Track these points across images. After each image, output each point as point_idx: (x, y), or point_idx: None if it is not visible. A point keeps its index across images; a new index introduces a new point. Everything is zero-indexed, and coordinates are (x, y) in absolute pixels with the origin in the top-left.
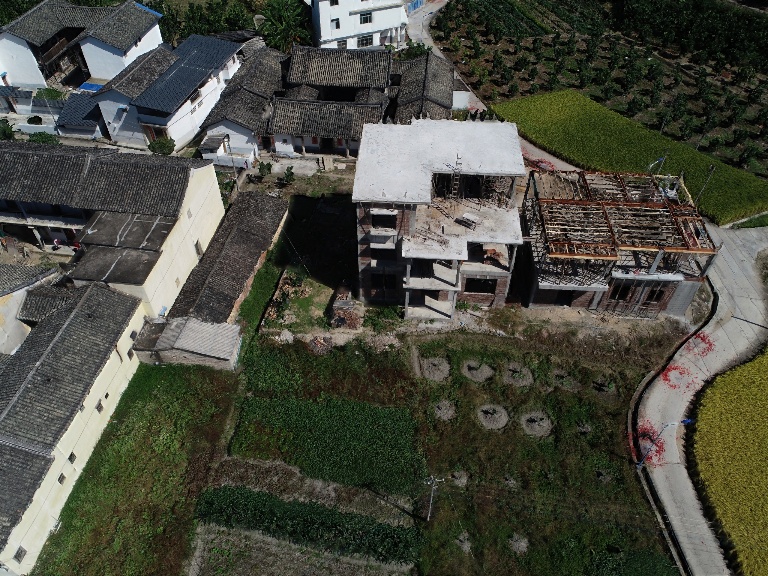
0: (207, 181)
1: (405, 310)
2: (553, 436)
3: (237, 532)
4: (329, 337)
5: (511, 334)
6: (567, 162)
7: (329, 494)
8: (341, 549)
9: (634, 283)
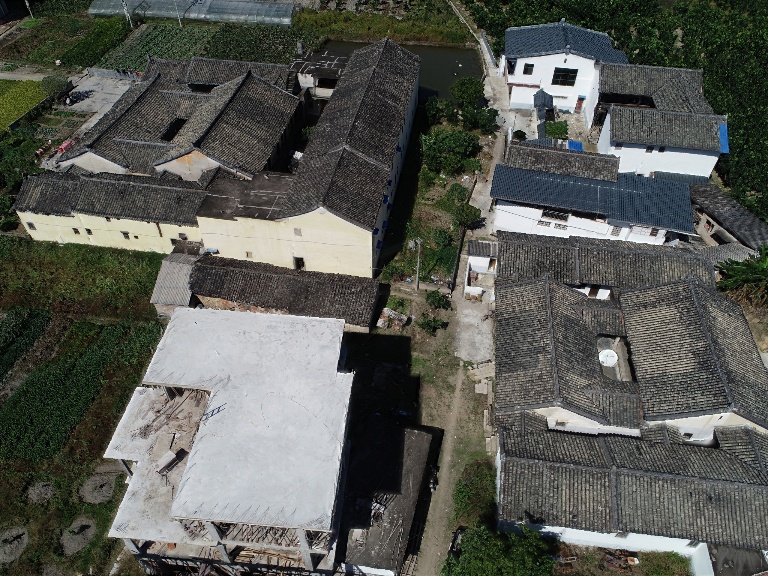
0: (351, 236)
1: None
2: None
3: None
4: None
5: None
6: None
7: (4, 390)
8: None
9: None
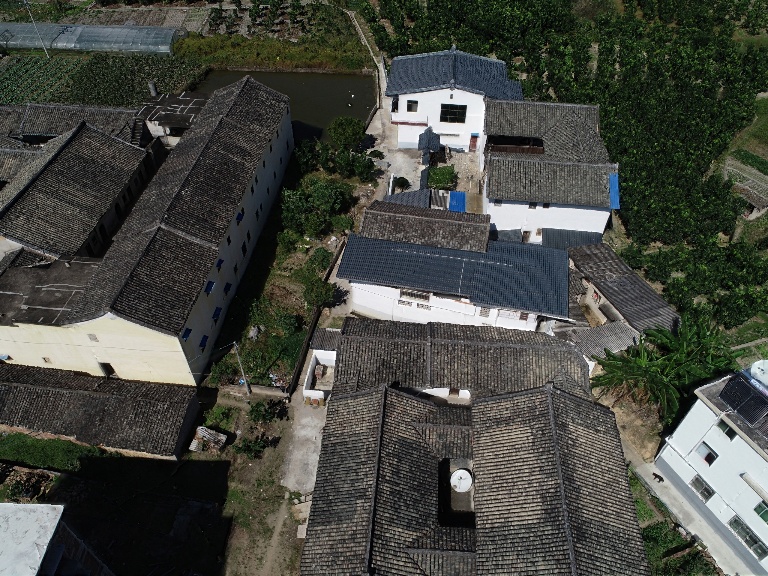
0: (155, 342)
1: None
2: None
3: None
4: None
5: None
6: None
7: None
8: None
9: None
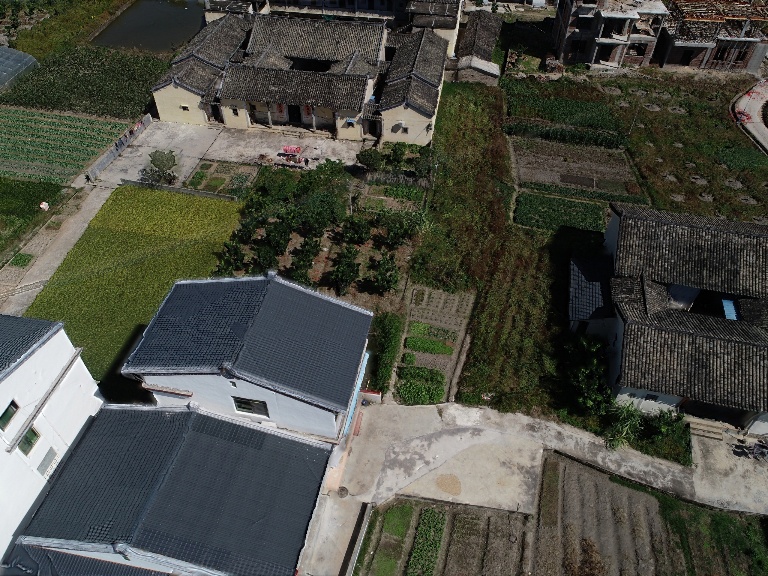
0: None
1: (592, 62)
2: (688, 113)
3: (527, 139)
4: (547, 76)
5: (654, 78)
6: (671, 10)
7: (571, 128)
8: (588, 139)
9: (731, 43)
